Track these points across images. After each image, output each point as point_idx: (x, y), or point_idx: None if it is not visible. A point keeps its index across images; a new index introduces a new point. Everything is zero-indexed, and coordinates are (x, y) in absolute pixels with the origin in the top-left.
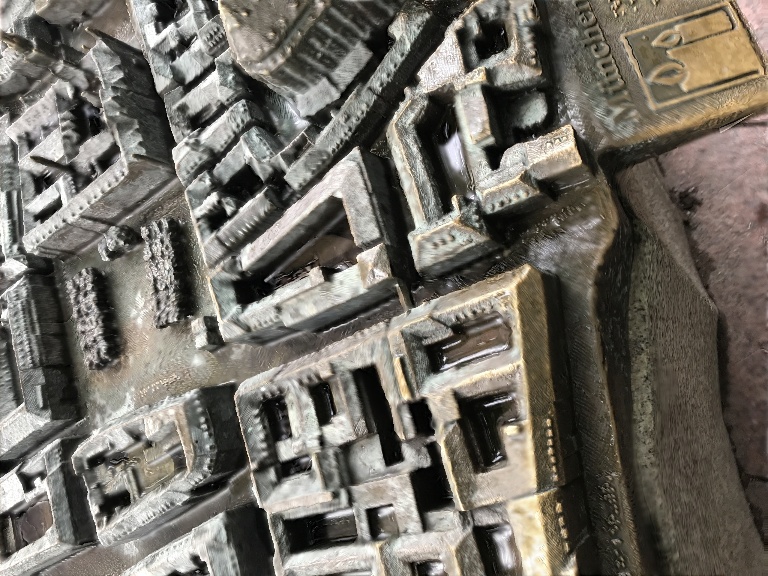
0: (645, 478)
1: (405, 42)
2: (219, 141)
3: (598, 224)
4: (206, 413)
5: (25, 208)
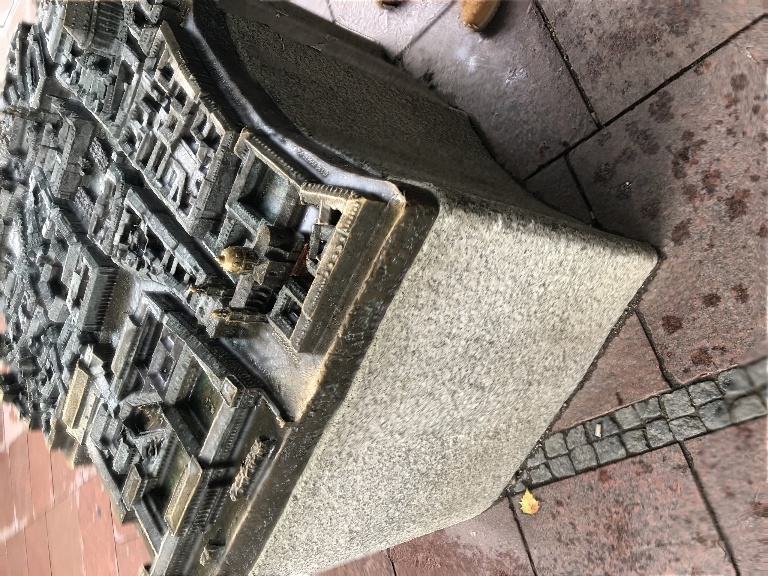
0: (251, 74)
1: (127, 6)
2: (96, 88)
3: (189, 6)
4: (117, 166)
5: (50, 182)
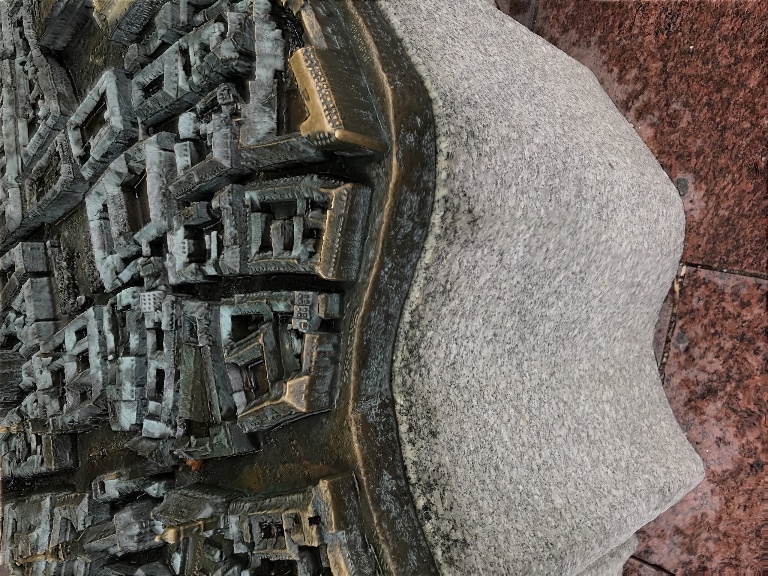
0: None
1: None
2: None
3: None
4: None
5: (87, 339)
